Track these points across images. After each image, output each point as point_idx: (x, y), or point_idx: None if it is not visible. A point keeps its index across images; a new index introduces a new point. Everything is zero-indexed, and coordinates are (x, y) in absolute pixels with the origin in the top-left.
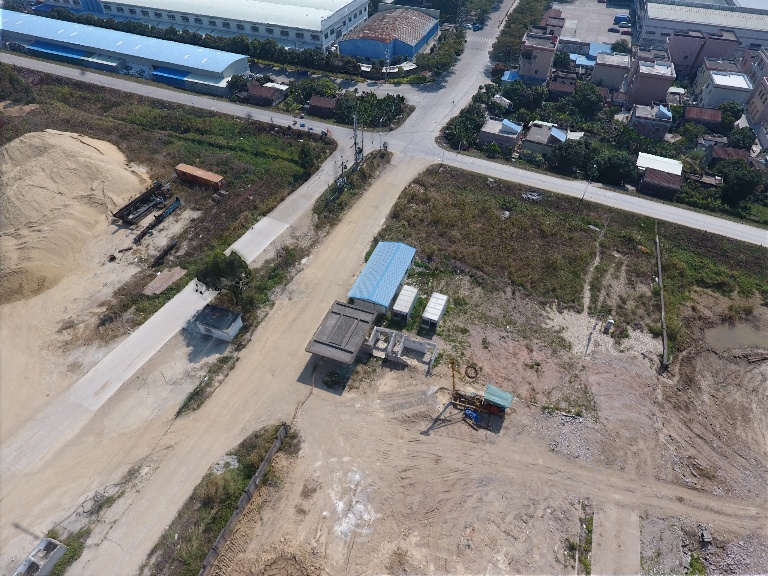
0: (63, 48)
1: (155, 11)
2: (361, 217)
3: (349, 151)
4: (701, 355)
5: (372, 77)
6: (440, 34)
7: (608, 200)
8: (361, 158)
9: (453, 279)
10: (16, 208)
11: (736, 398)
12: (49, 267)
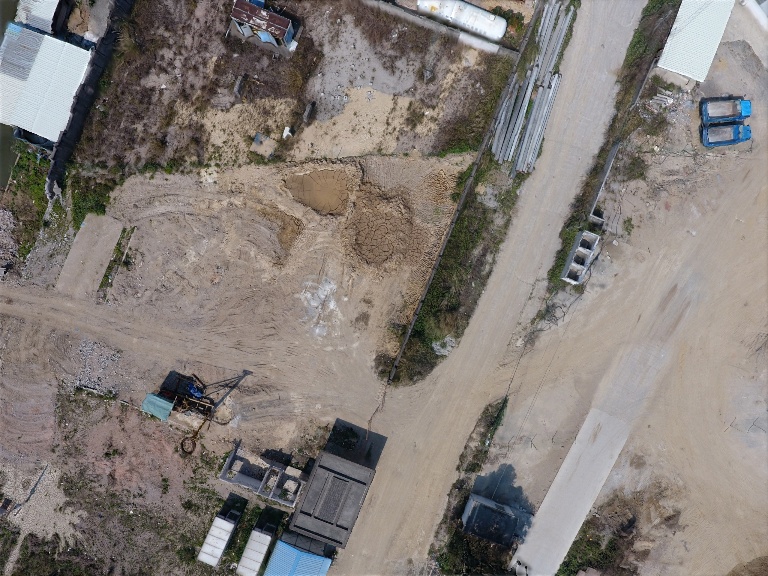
0: None
1: None
2: None
3: None
4: None
5: None
6: None
7: None
8: None
9: None
10: None
11: None
12: None
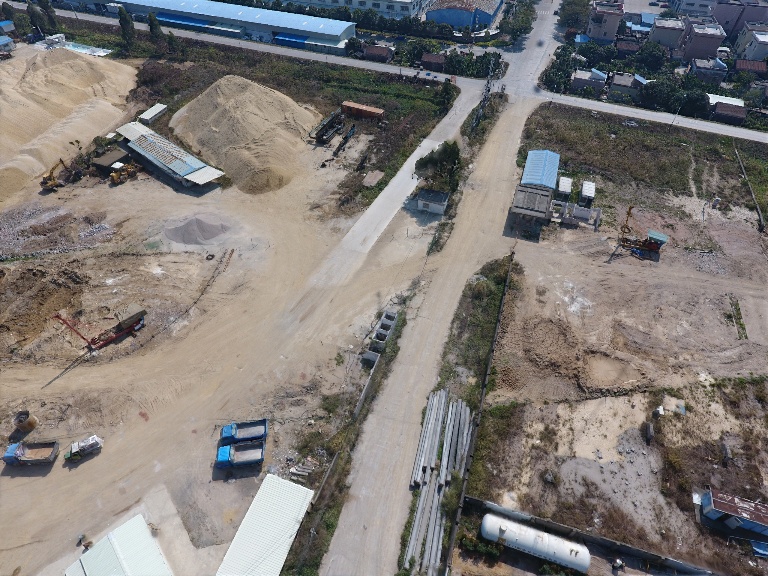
0: (187, 18)
1: None
2: (501, 138)
3: (472, 93)
4: None
5: (461, 41)
6: (504, 7)
7: (692, 125)
8: (487, 97)
9: (589, 177)
10: (244, 128)
11: None
12: (281, 170)
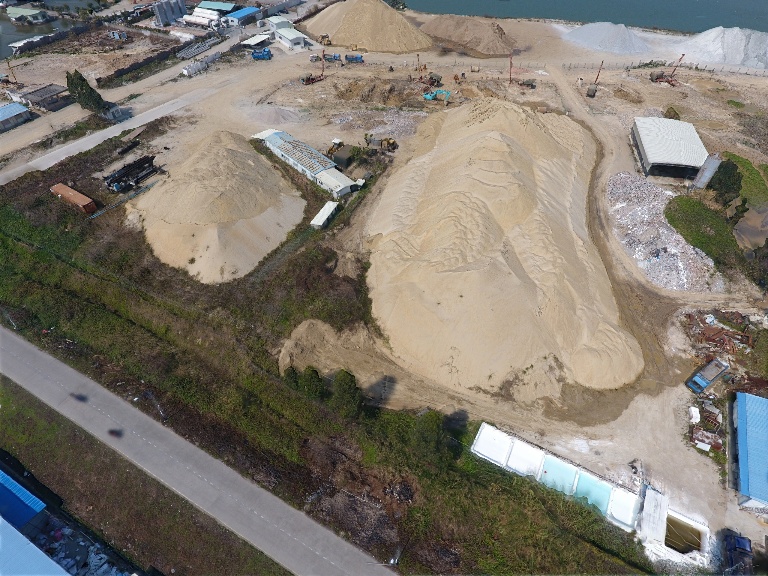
0: None
1: None
2: None
3: None
4: None
5: None
6: None
7: None
8: None
9: None
10: None
11: None
12: None
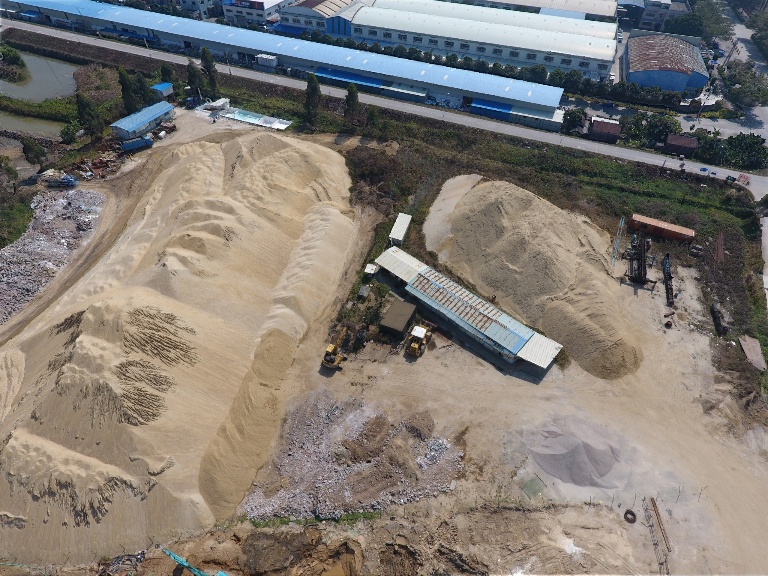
0: (355, 76)
1: (415, 35)
2: None
3: None
4: None
5: (681, 110)
6: None
7: None
8: None
9: None
10: (559, 270)
11: None
12: (627, 336)
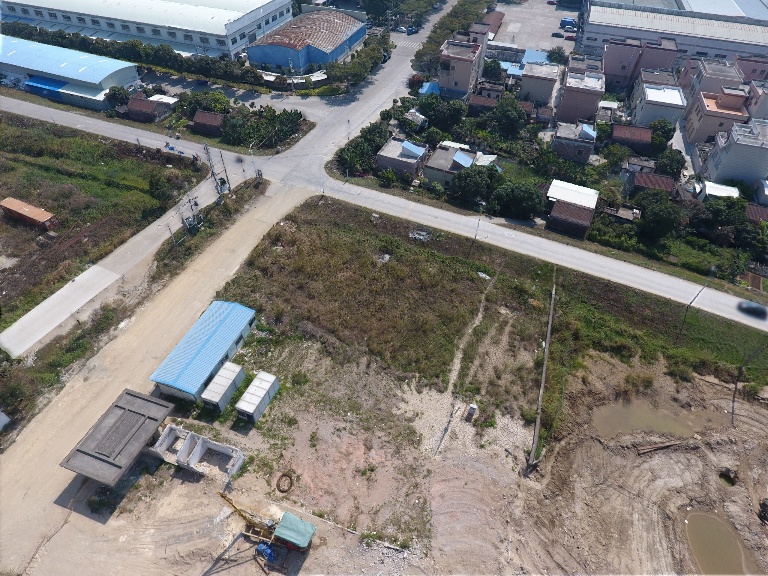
0: None
1: (48, 11)
2: (211, 264)
3: None
4: (583, 445)
5: (279, 88)
6: None
7: (505, 241)
8: (227, 189)
9: (299, 347)
10: None
11: (615, 506)
12: None
